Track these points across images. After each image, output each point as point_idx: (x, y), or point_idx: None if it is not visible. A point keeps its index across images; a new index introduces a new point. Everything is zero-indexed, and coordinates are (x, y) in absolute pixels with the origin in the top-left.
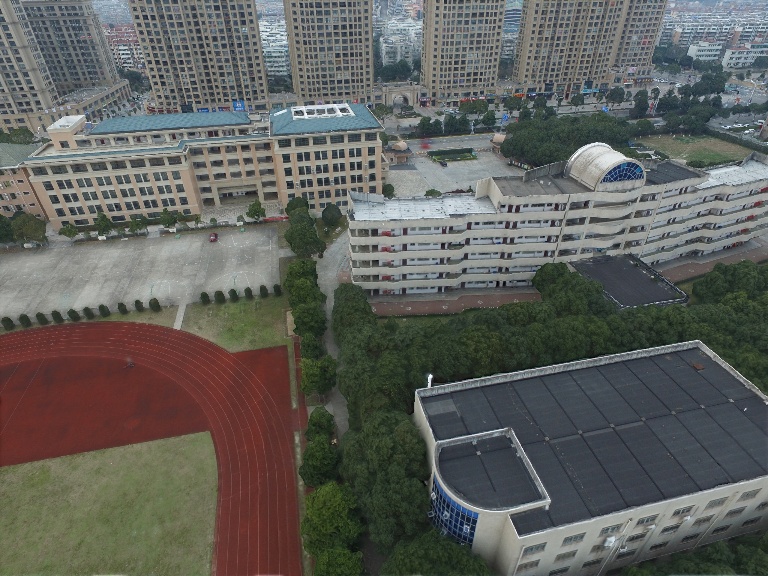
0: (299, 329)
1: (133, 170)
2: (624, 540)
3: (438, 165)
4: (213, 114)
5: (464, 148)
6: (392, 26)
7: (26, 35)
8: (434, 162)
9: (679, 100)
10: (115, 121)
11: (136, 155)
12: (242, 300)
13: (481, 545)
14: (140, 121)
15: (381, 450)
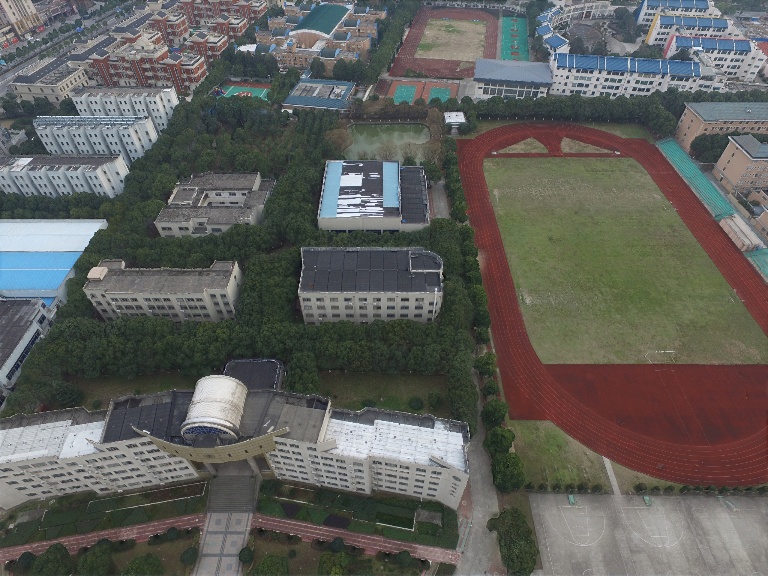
0: None
1: None
2: None
3: None
4: None
5: None
6: None
7: None
8: None
9: None
10: None
11: None
12: (562, 487)
13: None
14: None
15: None
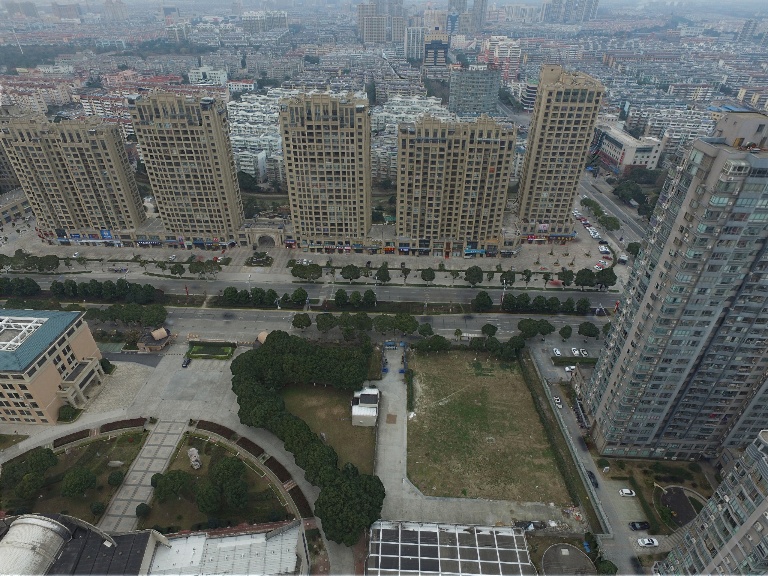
0: None
1: None
2: None
3: (182, 363)
4: None
5: (226, 342)
6: (378, 112)
7: None
8: (184, 357)
9: (529, 300)
10: None
11: None
12: None
13: None
14: None
15: None
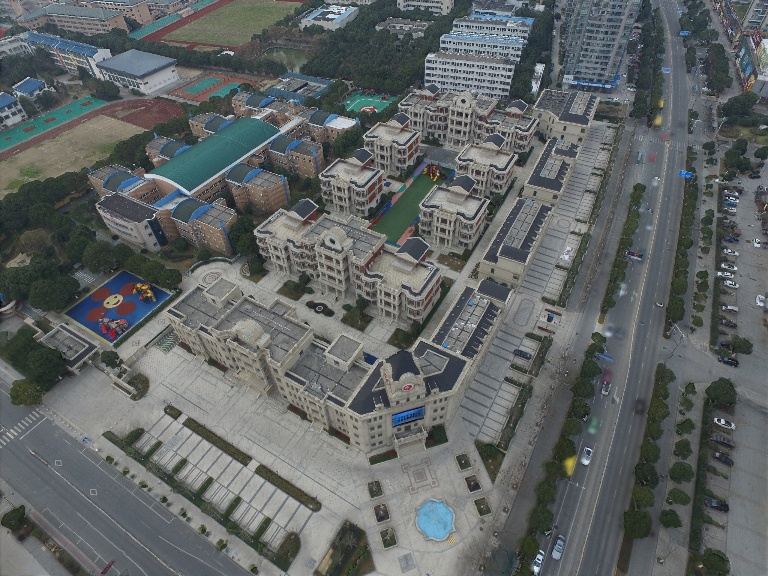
0: None
1: None
2: (341, 4)
3: None
4: None
5: None
6: None
7: None
8: None
9: None
10: None
11: None
12: None
13: (325, 1)
14: None
15: None
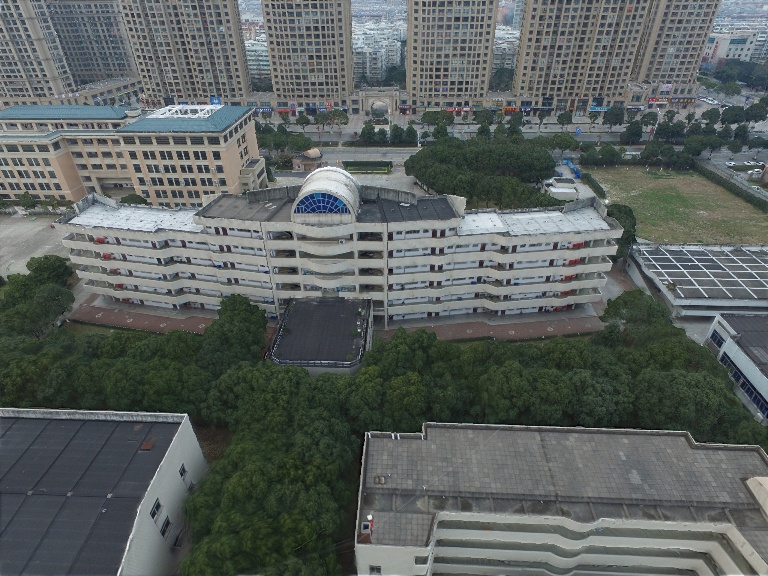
0: None
1: (8, 154)
2: None
3: None
4: (95, 108)
5: (382, 161)
6: None
7: (43, 29)
8: None
9: (685, 126)
10: (12, 108)
11: (9, 140)
12: (7, 286)
13: None
14: (31, 110)
15: None
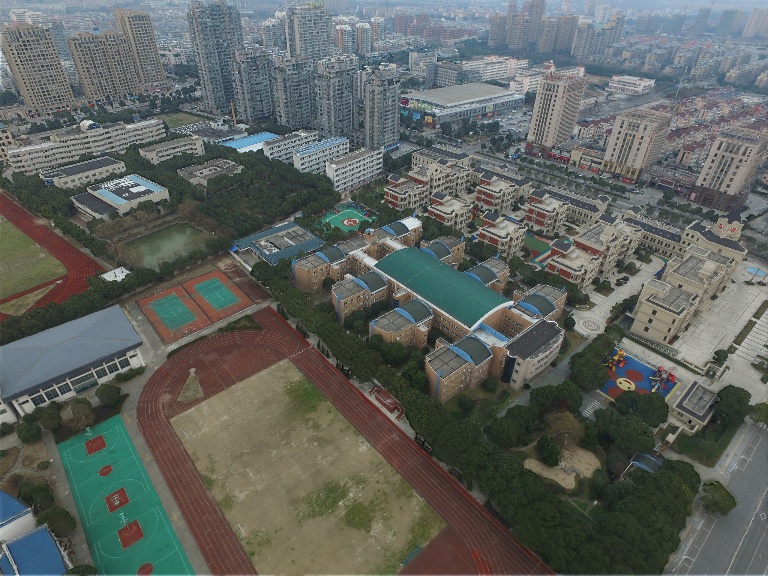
0: (3, 186)
1: None
2: None
3: None
4: None
5: None
6: None
7: None
8: None
9: (170, 98)
10: None
11: None
12: None
13: None
14: None
15: (34, 183)
